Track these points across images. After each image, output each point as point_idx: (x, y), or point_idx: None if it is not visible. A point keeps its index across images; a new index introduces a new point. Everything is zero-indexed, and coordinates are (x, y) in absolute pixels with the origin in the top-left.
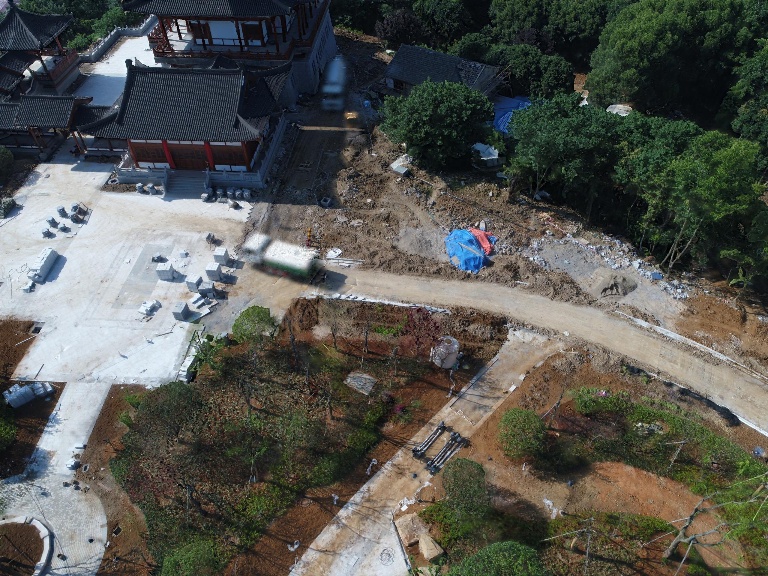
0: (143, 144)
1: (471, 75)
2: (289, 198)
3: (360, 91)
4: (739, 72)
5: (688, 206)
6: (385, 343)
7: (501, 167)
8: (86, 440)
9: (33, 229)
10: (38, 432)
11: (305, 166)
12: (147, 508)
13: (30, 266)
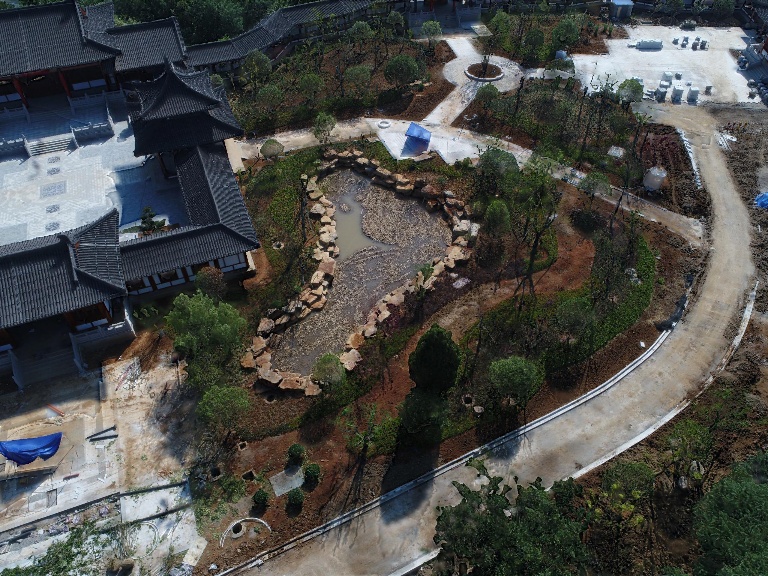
0: None
1: None
2: None
3: None
4: None
5: None
6: None
7: None
8: (545, 79)
9: None
10: None
11: None
12: None
13: None
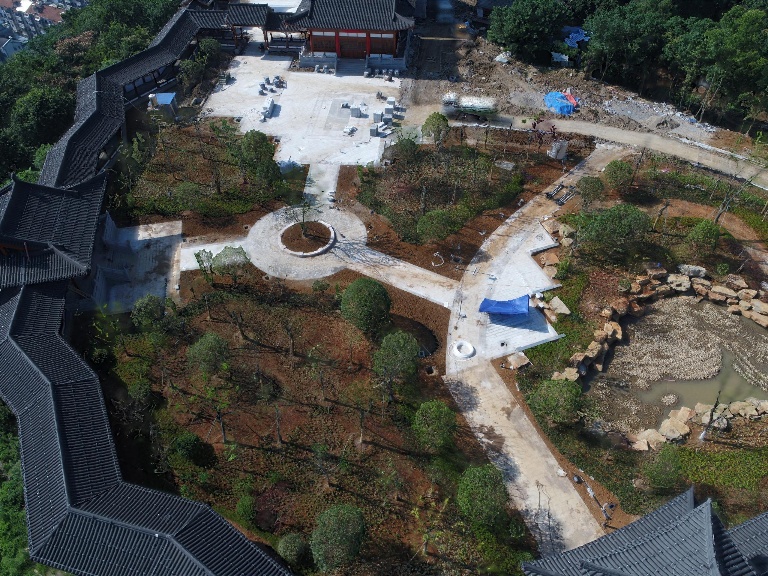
0: (321, 37)
1: None
2: (426, 76)
3: (459, 17)
4: (747, 2)
5: (716, 65)
6: (516, 147)
7: (571, 68)
8: (335, 189)
9: (249, 91)
10: (302, 186)
11: (431, 59)
12: (389, 215)
13: (257, 109)
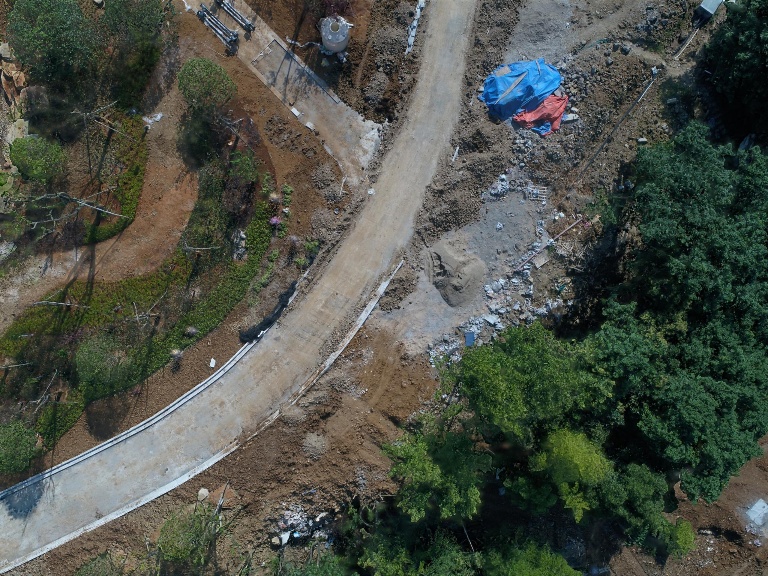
0: None
1: None
2: None
3: None
4: None
5: None
6: None
7: None
8: None
9: None
10: None
11: None
12: None
13: None
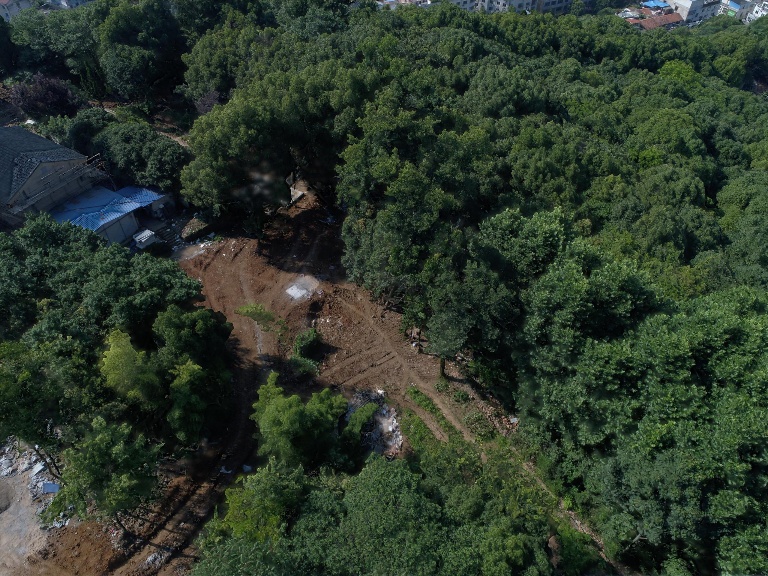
0: None
1: (23, 172)
2: None
3: None
4: (338, 172)
5: None
6: None
7: None
8: None
9: None
10: None
11: None
12: None
13: None
